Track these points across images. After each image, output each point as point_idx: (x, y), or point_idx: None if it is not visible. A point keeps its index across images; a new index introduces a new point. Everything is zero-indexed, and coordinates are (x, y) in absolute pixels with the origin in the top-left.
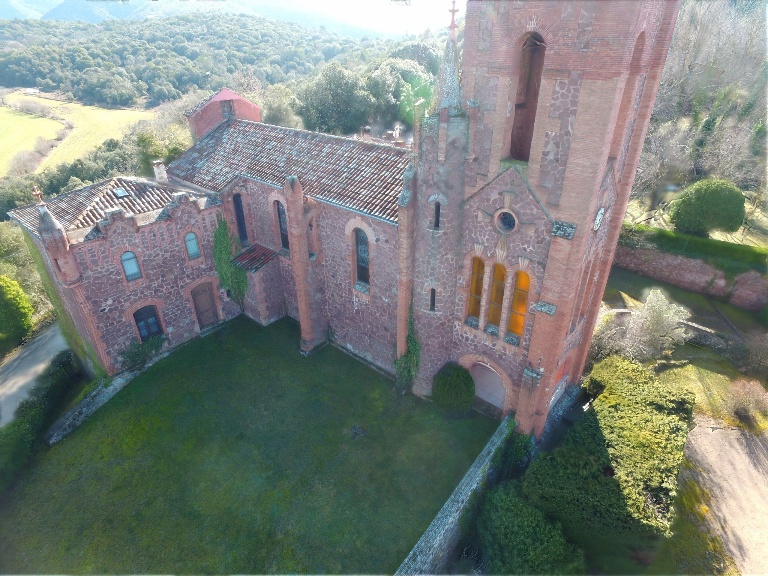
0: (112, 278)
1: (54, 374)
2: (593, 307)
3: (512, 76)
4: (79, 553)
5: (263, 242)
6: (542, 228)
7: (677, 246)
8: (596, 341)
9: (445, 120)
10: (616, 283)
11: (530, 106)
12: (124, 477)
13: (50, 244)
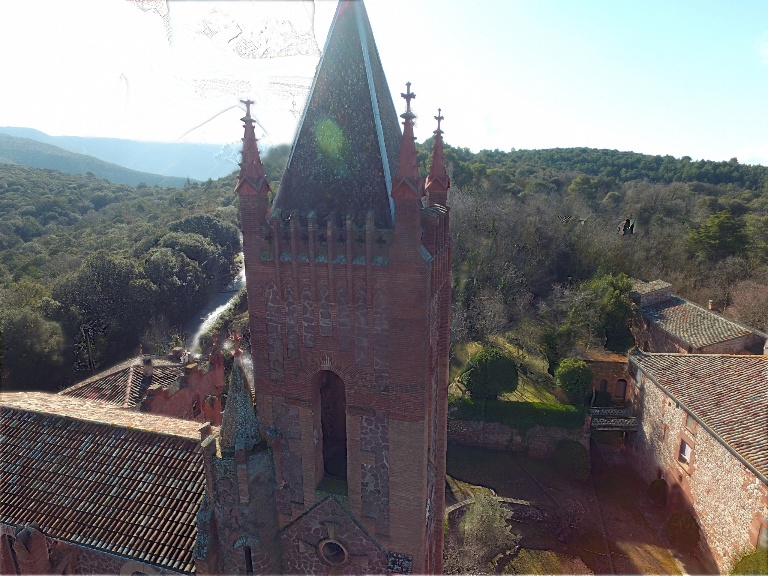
0: None
1: None
2: None
3: (314, 406)
4: None
5: None
6: (376, 559)
7: (477, 412)
8: None
9: (243, 461)
10: None
11: (333, 386)
12: None
13: None
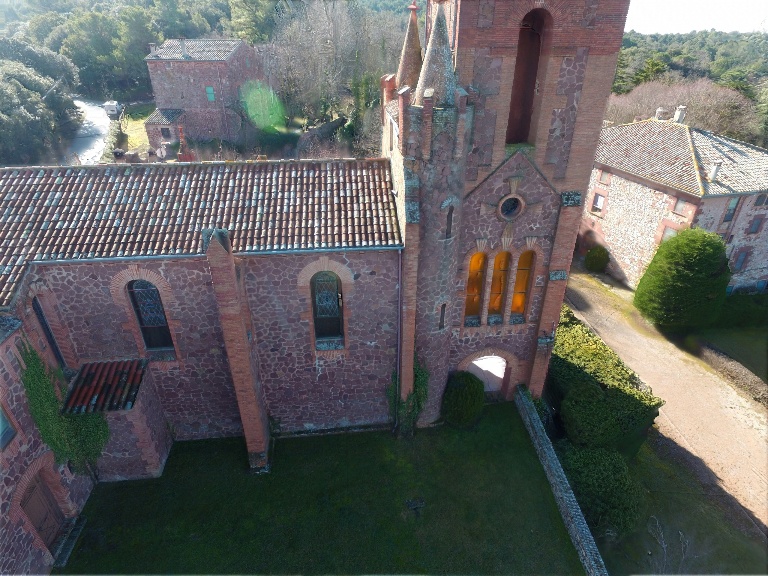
0: None
1: None
2: None
3: None
4: None
5: (100, 357)
6: (549, 203)
7: None
8: None
9: (464, 110)
10: None
11: None
12: None
13: None
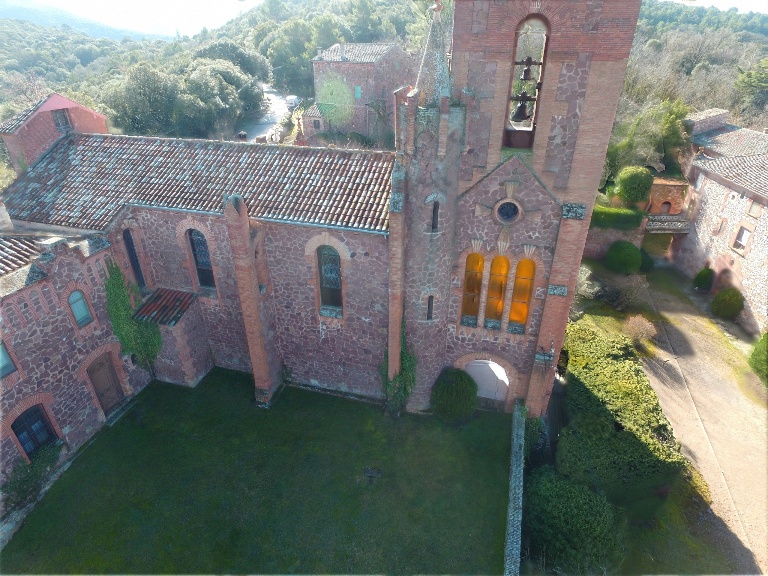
0: None
1: None
2: None
3: None
4: None
5: (169, 284)
6: (549, 213)
7: None
8: None
9: (446, 111)
10: None
11: None
12: None
13: None
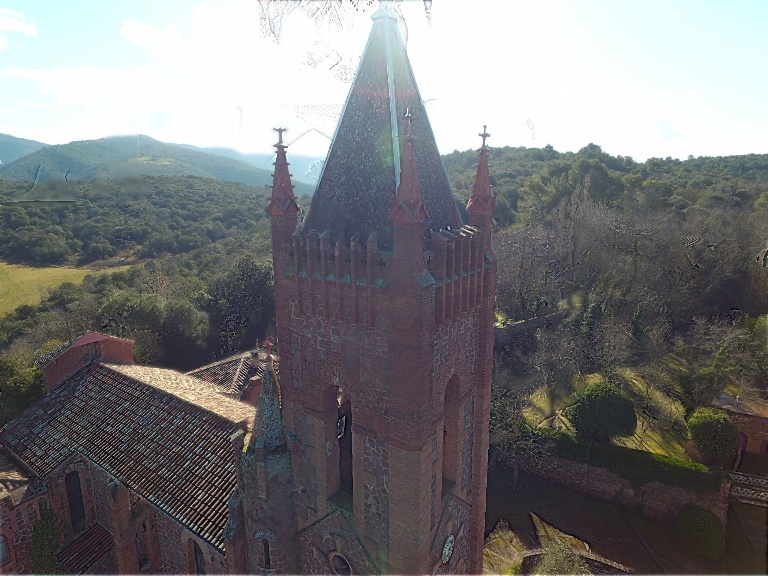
0: None
1: None
2: None
3: (327, 418)
4: None
5: (104, 523)
6: None
7: (581, 453)
8: None
9: (262, 459)
10: (527, 500)
11: None
12: None
13: None
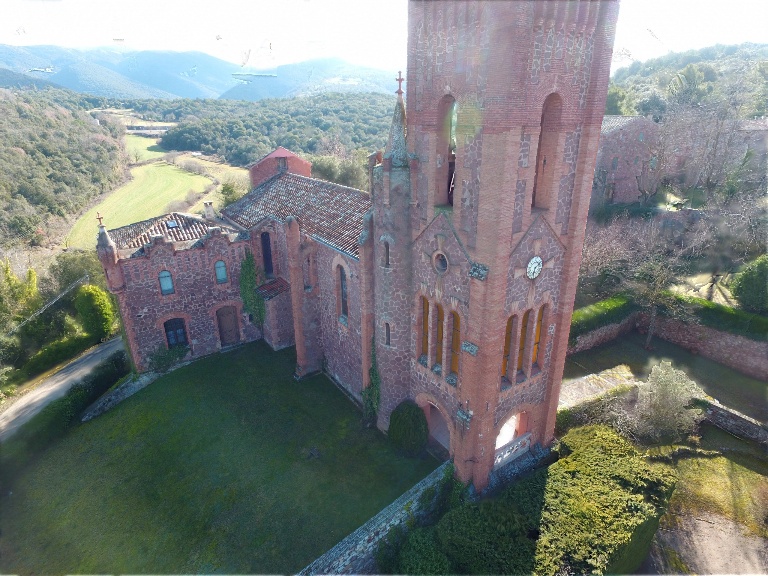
0: (150, 291)
1: (105, 367)
2: (553, 362)
3: (439, 132)
4: (64, 509)
5: (284, 276)
6: (465, 269)
7: (737, 325)
8: (587, 407)
9: (387, 169)
10: (658, 358)
11: None
12: (119, 456)
13: (103, 257)
